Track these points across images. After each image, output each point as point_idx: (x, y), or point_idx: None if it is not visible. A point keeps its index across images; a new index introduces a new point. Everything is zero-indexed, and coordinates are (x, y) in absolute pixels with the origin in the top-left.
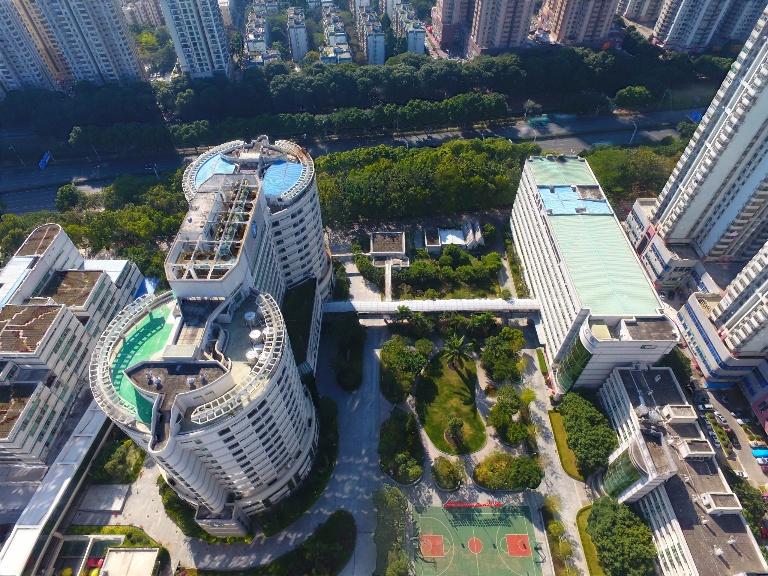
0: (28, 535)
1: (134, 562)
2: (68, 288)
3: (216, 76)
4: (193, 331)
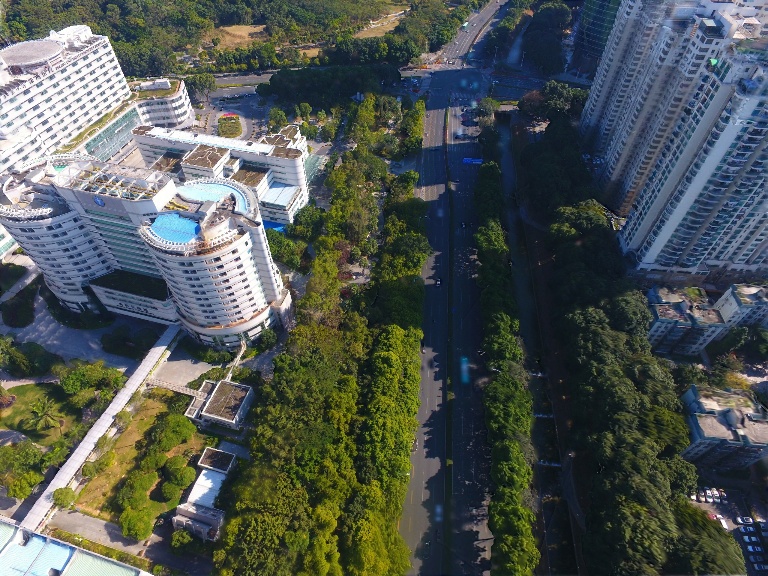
0: None
1: None
2: (249, 175)
3: (611, 253)
4: None
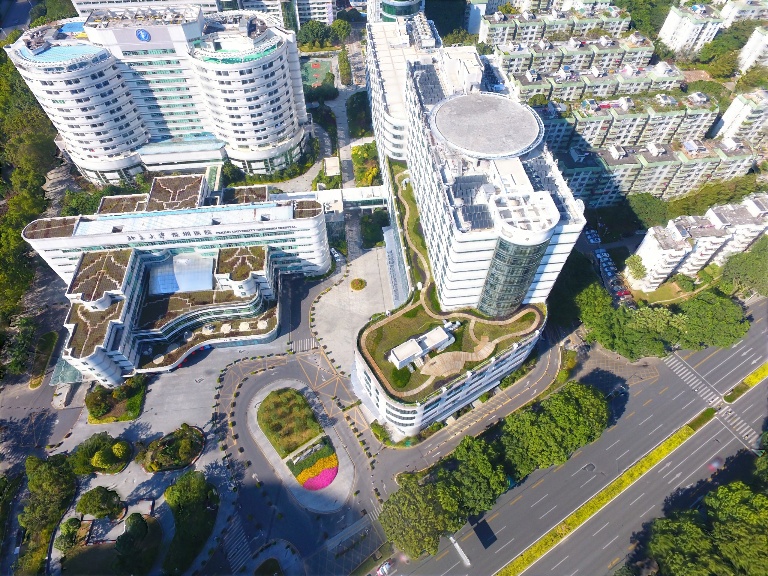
0: (321, 196)
1: (331, 166)
2: None
3: None
4: (228, 30)
